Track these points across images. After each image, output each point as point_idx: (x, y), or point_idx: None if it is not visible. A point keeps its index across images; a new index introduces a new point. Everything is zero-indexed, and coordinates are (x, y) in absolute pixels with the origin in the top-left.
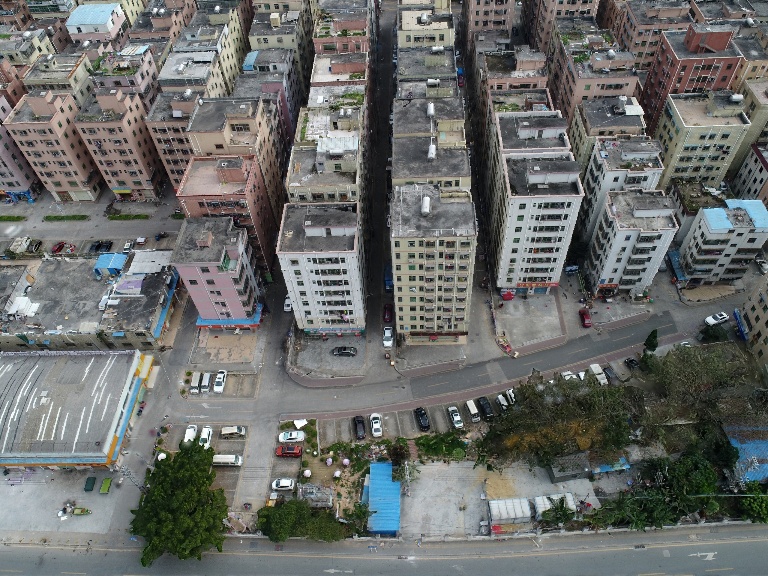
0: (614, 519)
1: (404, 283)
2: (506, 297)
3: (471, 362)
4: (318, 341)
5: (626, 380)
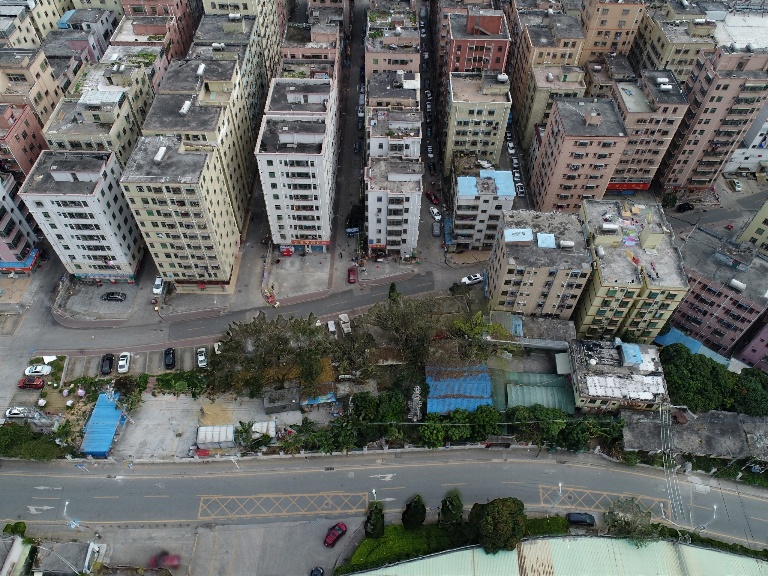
0: (303, 443)
1: (149, 229)
2: (285, 254)
3: (233, 310)
4: (92, 287)
5: (355, 326)
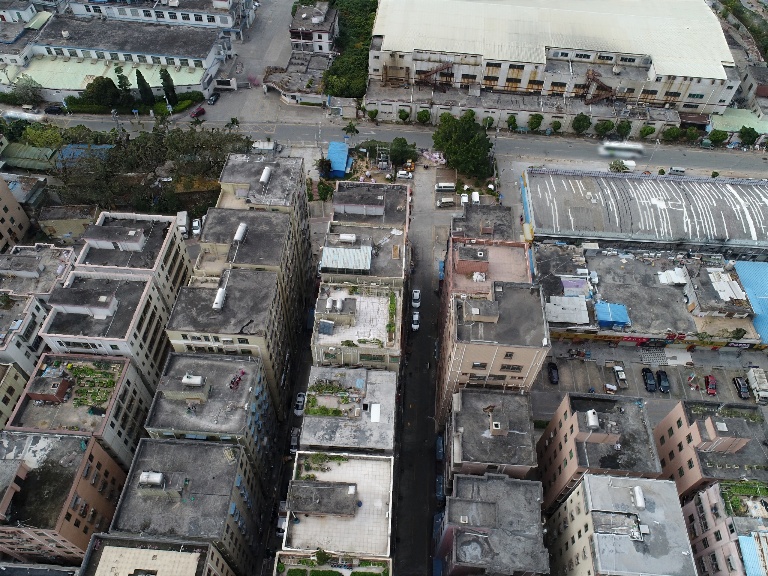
0: None
1: None
2: None
3: None
4: None
5: (145, 199)
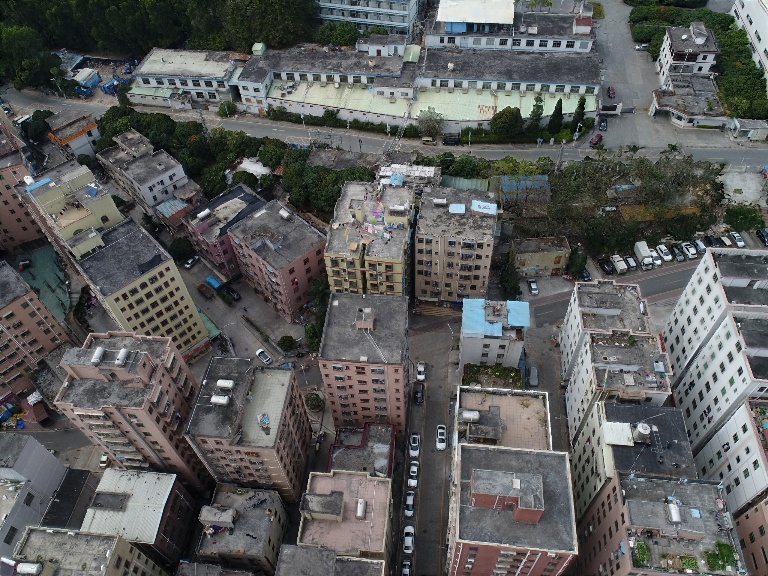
0: None
1: None
2: None
3: None
4: None
5: None
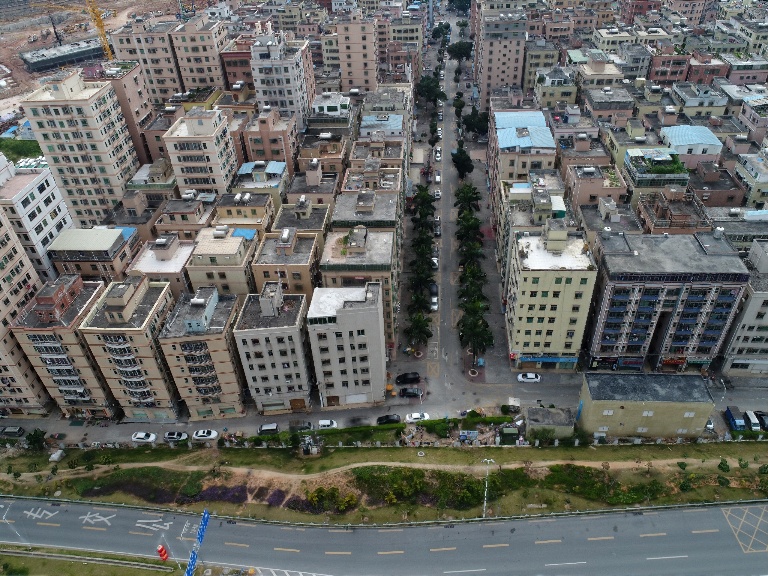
0: None
1: None
2: None
3: None
4: None
5: None
